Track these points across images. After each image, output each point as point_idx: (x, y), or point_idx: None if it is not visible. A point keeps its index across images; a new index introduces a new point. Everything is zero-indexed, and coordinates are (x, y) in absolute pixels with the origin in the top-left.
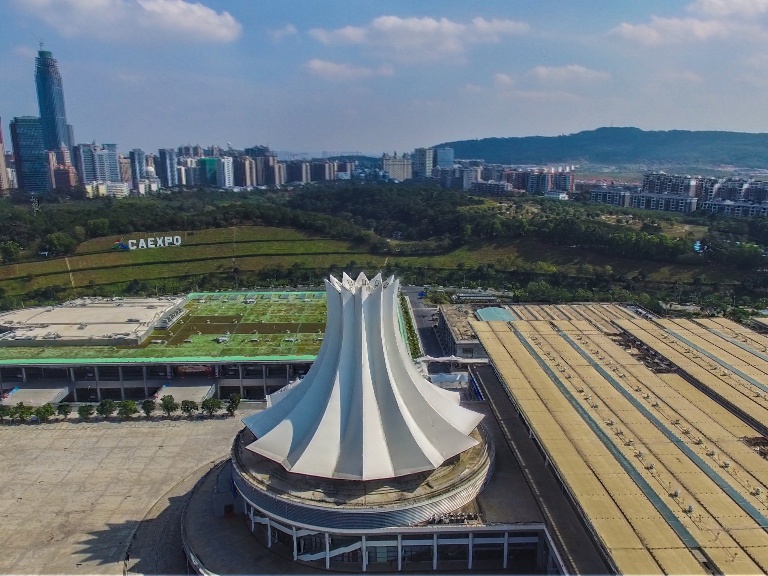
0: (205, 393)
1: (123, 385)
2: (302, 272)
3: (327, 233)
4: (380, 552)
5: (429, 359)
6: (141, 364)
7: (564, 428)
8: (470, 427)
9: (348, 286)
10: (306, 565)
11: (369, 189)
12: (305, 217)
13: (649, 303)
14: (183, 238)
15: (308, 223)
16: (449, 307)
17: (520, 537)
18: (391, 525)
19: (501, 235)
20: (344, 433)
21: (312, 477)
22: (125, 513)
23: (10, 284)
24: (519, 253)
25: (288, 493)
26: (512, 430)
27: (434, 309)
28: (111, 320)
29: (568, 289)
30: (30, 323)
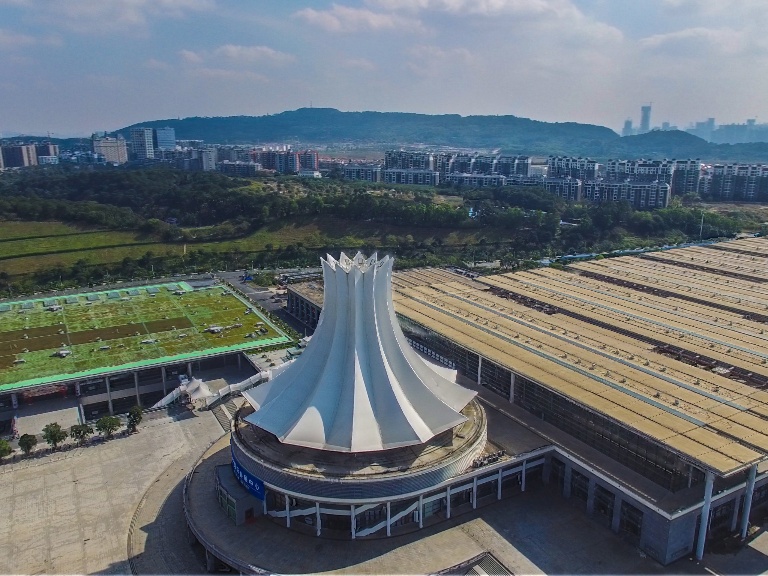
0: (76, 415)
1: None
2: (91, 270)
3: (105, 224)
4: (427, 507)
5: None
6: None
7: (538, 366)
8: None
9: None
10: (368, 539)
11: (112, 174)
12: (73, 207)
13: (457, 264)
14: None
15: (79, 214)
16: (299, 286)
17: (533, 462)
18: (448, 478)
19: (297, 214)
20: (375, 407)
21: (361, 454)
22: (100, 558)
23: None
24: (321, 230)
25: (349, 474)
26: (460, 382)
27: (267, 292)
28: None
29: (379, 259)
30: None
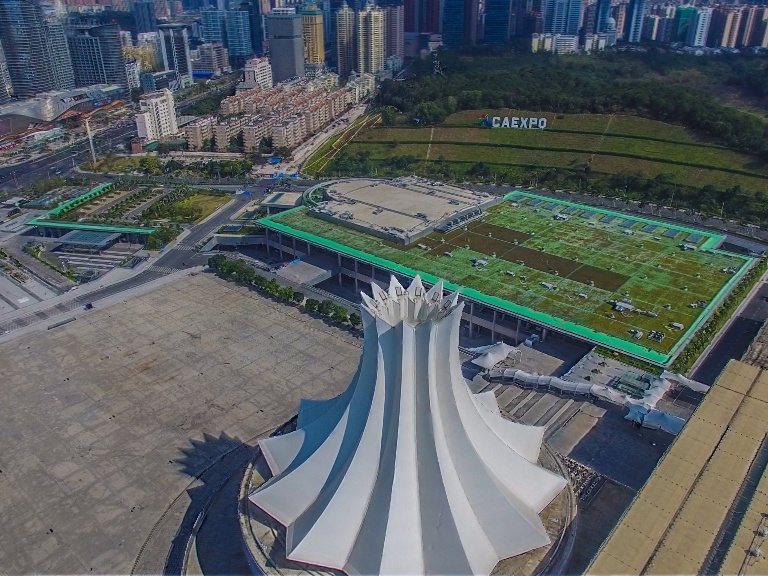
0: None
1: None
2: (663, 188)
3: (726, 139)
4: None
5: (679, 380)
6: (385, 269)
7: None
8: (514, 549)
9: (413, 296)
10: None
11: None
12: (704, 113)
13: None
14: (550, 121)
15: (704, 122)
16: None
17: None
18: None
19: None
20: (330, 481)
21: None
22: (243, 427)
23: (378, 147)
24: None
25: None
26: None
27: None
28: (405, 210)
29: None
30: (346, 196)
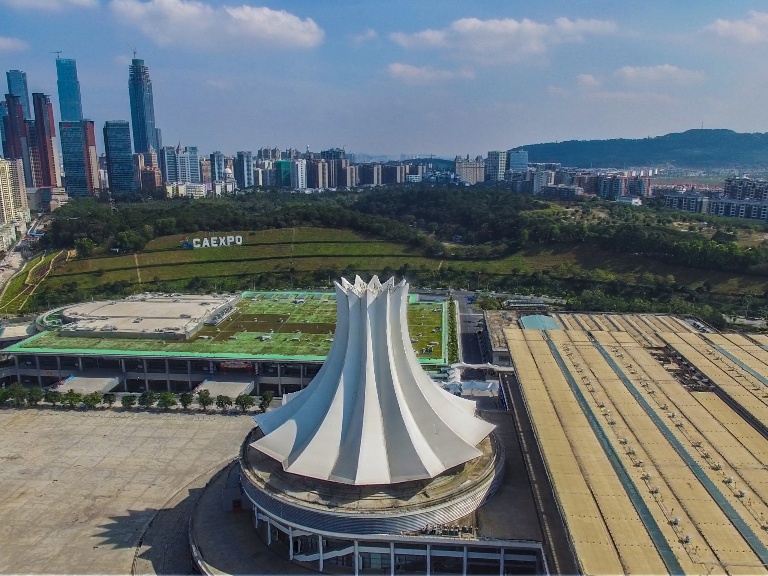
0: (243, 389)
1: (169, 378)
2: None
3: (384, 235)
4: (374, 558)
5: (464, 365)
6: (185, 358)
7: (573, 444)
8: (479, 437)
9: (360, 289)
10: (301, 565)
11: (434, 192)
12: (363, 219)
13: (711, 316)
14: (245, 238)
15: (365, 225)
16: (493, 313)
17: (517, 554)
18: (382, 532)
19: (560, 241)
20: (345, 436)
21: (310, 478)
22: (147, 501)
23: (83, 278)
24: (577, 260)
25: (284, 492)
26: (530, 443)
27: (482, 315)
28: (165, 315)
29: (626, 298)
30: (92, 315)
